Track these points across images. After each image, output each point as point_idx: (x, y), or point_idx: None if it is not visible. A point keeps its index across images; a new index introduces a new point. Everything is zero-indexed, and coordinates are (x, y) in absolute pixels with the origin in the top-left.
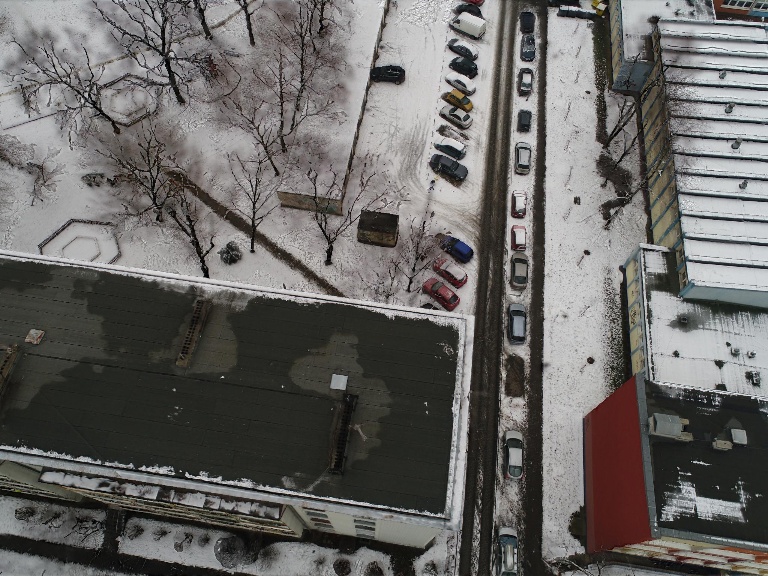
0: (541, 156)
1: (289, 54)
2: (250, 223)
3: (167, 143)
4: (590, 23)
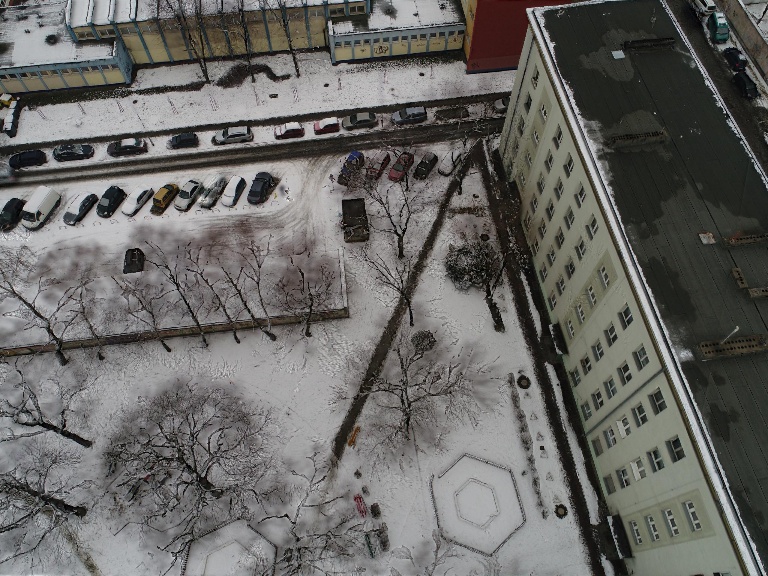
0: (227, 126)
1: (106, 390)
2: (379, 340)
3: (292, 479)
4: (28, 109)
